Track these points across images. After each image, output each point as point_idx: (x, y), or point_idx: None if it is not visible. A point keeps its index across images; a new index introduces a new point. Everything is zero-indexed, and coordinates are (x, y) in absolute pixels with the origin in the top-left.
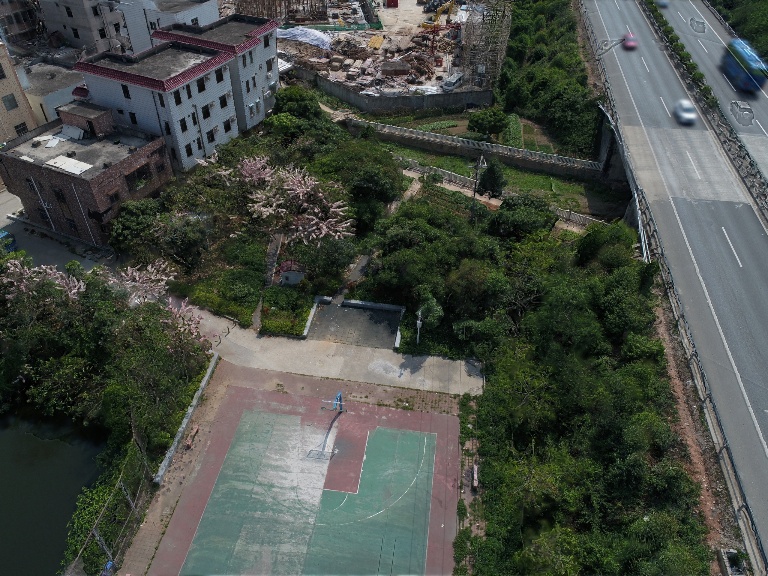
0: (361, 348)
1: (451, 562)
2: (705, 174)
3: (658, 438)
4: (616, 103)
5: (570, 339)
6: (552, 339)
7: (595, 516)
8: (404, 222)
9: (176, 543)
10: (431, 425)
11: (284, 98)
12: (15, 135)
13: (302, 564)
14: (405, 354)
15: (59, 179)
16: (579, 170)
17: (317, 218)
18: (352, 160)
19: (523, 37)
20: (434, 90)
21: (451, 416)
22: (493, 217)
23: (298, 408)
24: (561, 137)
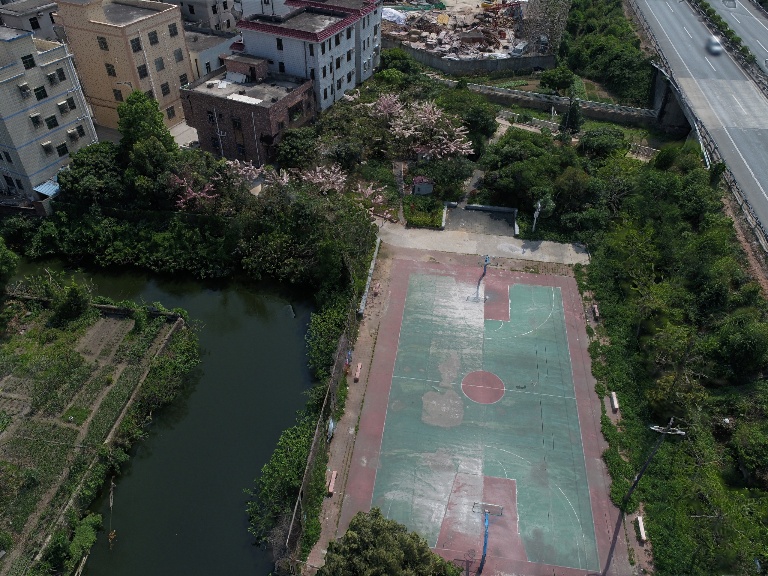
0: (488, 236)
1: (589, 359)
2: (750, 111)
3: (736, 275)
4: (668, 61)
5: (660, 218)
6: (648, 215)
7: (692, 328)
8: (514, 143)
9: (386, 348)
10: (555, 282)
11: (389, 57)
12: (179, 83)
13: (481, 360)
14: (524, 239)
15: (240, 109)
16: (637, 117)
17: (446, 139)
18: (458, 102)
19: (576, 13)
20: (504, 56)
21: (569, 277)
22: (581, 142)
23: (451, 272)
24: (620, 91)
